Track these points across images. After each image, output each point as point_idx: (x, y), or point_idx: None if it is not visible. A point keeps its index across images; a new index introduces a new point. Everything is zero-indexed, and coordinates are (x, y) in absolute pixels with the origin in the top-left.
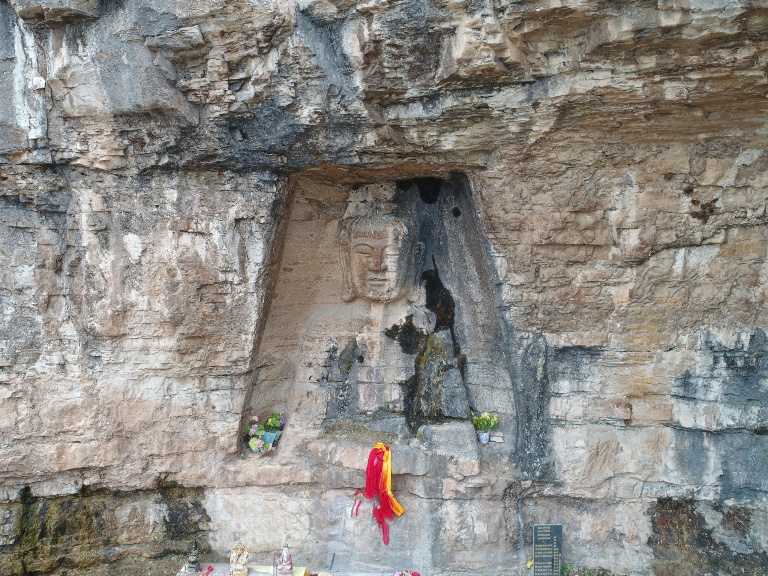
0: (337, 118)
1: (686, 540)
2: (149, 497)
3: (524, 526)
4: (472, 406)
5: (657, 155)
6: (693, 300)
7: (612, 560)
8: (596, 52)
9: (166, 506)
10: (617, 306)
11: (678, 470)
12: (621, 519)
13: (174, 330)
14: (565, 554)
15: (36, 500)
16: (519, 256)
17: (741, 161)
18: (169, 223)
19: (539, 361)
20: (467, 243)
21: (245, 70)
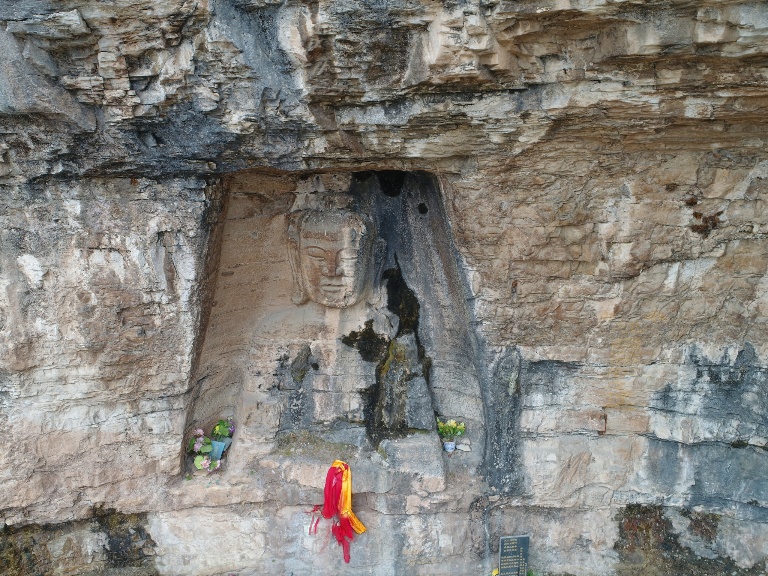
0: (276, 124)
1: (652, 544)
2: (85, 526)
3: (490, 536)
4: (437, 411)
5: (661, 164)
6: (682, 314)
7: (578, 565)
8: (607, 62)
9: (105, 534)
10: (600, 321)
11: (650, 479)
12: (589, 526)
13: (94, 357)
14: (531, 560)
15: None
16: (495, 272)
17: (756, 174)
18: (74, 240)
19: (512, 376)
20: (434, 243)
21: (150, 66)
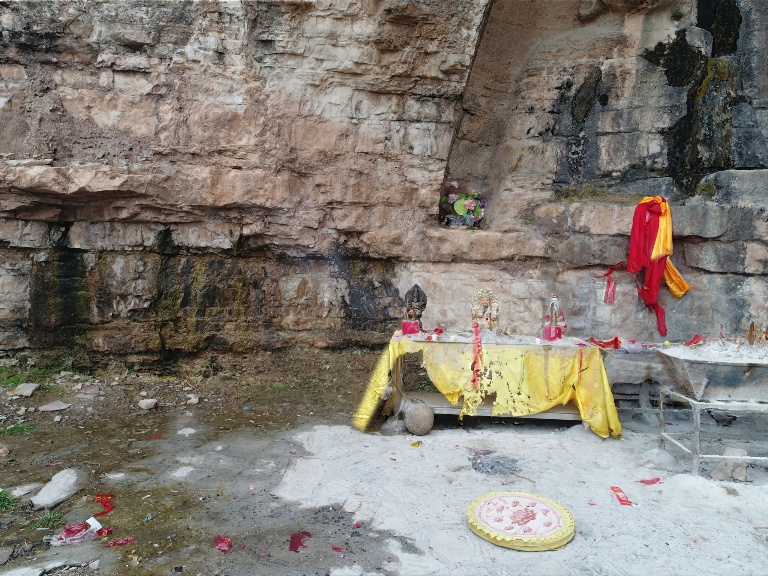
0: None
1: None
2: (322, 269)
3: None
4: None
5: None
6: None
7: None
8: None
9: (345, 282)
10: None
11: None
12: None
13: (375, 7)
14: None
15: (177, 253)
16: None
17: None
18: None
19: None
20: None
21: None
